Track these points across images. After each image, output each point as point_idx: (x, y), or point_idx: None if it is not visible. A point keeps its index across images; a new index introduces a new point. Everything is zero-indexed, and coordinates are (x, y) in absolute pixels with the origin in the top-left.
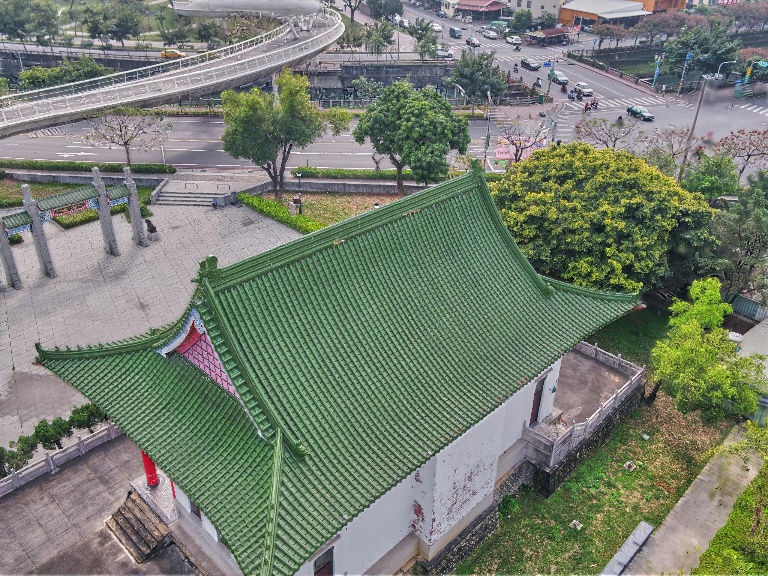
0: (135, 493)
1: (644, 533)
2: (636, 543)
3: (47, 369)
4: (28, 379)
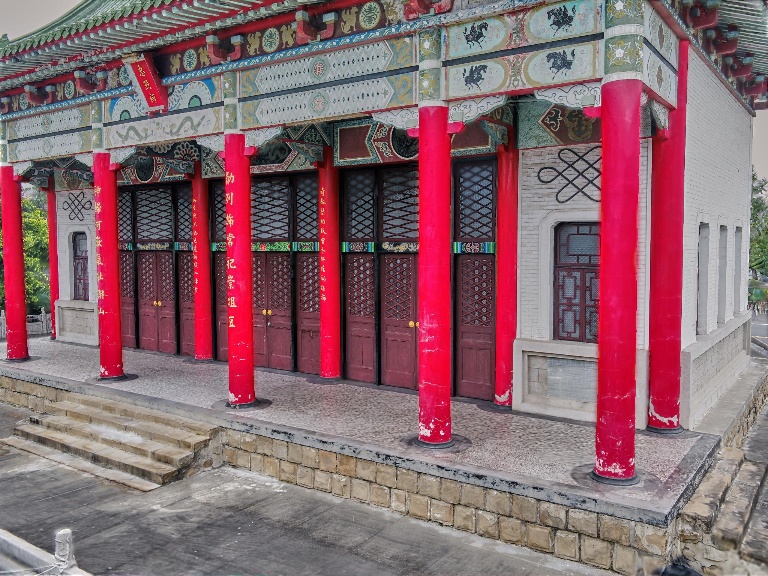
0: (687, 508)
1: None
2: None
3: None
4: None
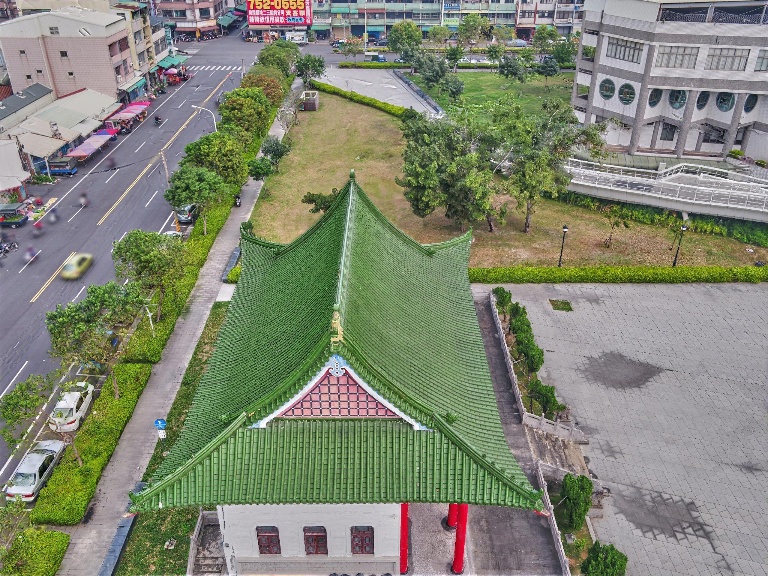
0: None
1: (106, 565)
2: (112, 549)
3: (656, 383)
4: (647, 372)
